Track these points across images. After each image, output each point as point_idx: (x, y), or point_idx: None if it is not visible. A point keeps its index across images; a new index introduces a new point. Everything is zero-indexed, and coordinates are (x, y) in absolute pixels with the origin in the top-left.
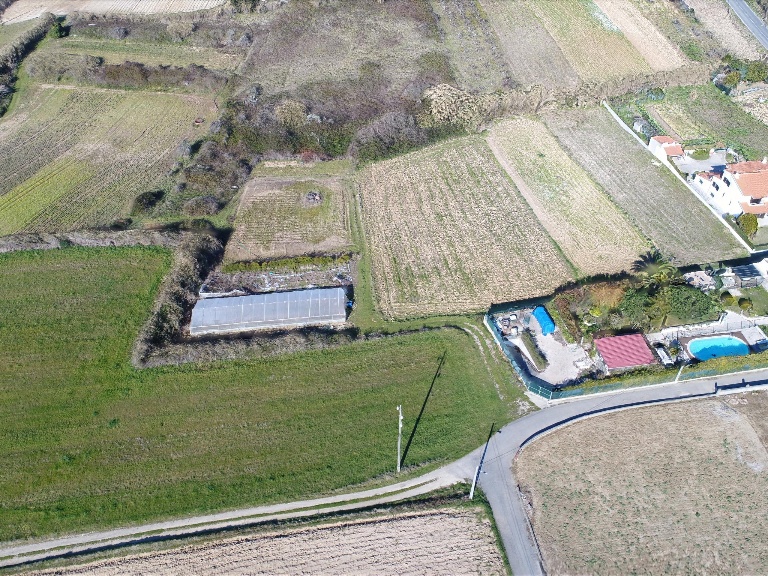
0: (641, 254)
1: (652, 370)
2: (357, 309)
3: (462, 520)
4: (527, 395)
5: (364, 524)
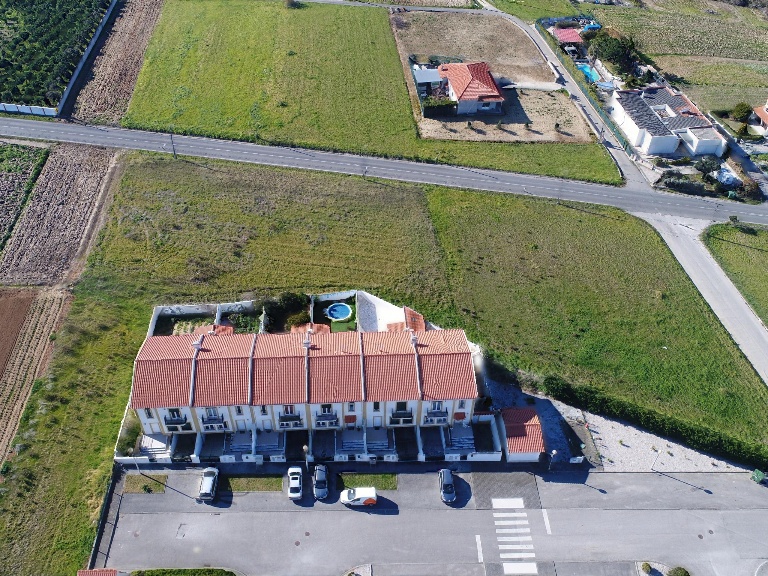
0: (685, 77)
1: None
2: (595, 4)
3: (465, 3)
4: None
5: None
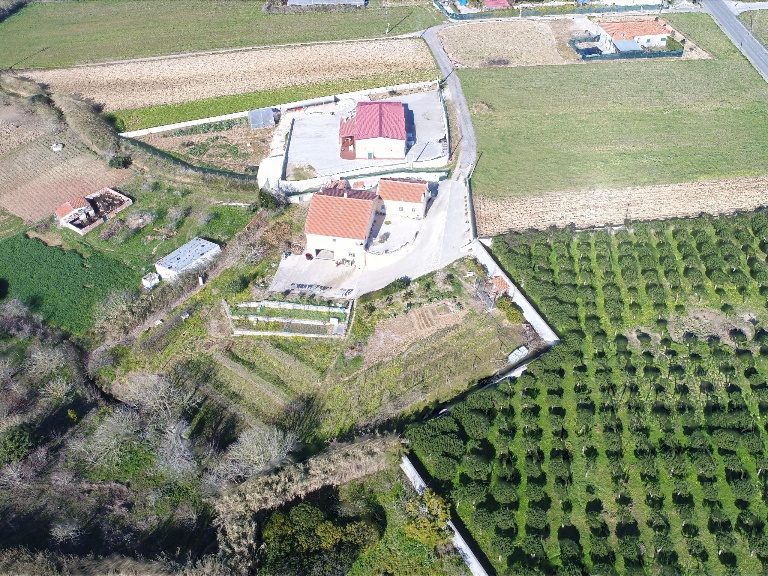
0: None
1: (508, 9)
2: (370, 5)
3: (413, 41)
4: (449, 20)
5: (371, 42)
